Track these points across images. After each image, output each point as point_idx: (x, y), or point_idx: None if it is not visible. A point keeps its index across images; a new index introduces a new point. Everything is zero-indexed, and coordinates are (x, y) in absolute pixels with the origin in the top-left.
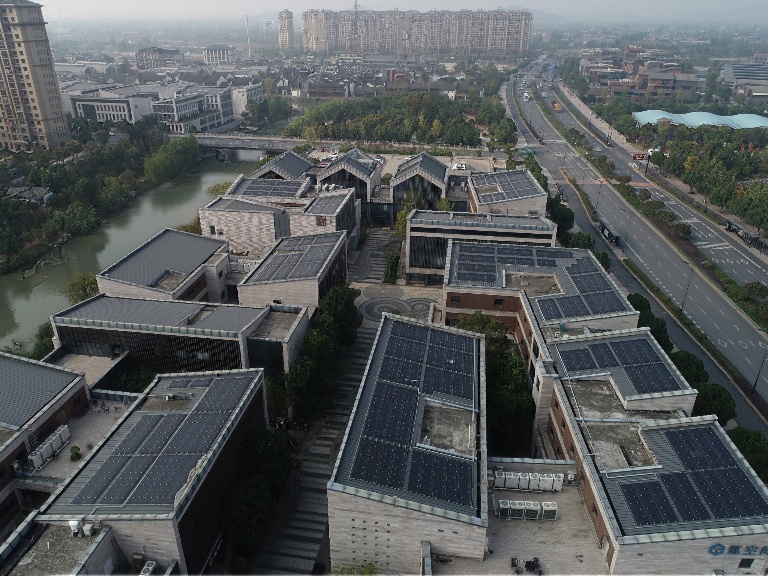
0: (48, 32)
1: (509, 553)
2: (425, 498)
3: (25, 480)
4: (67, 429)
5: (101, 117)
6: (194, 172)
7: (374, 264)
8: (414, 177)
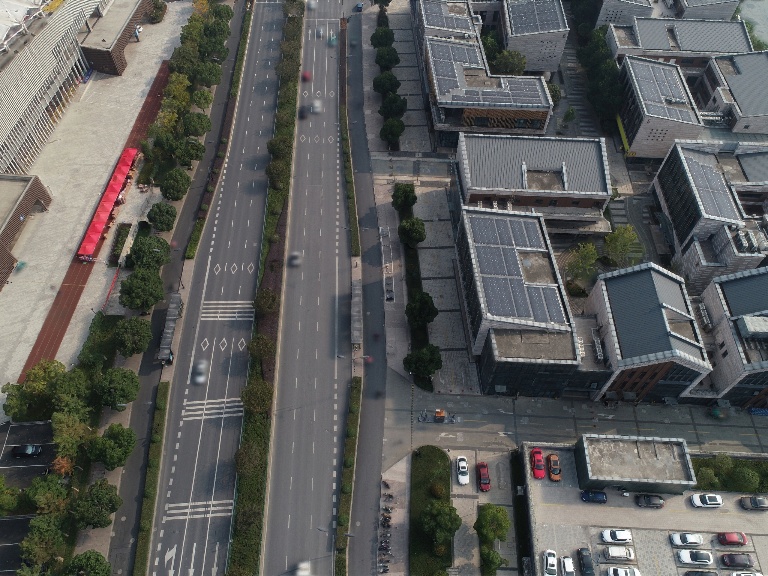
0: None
1: None
2: None
3: None
4: (670, 4)
5: None
6: None
7: None
8: None
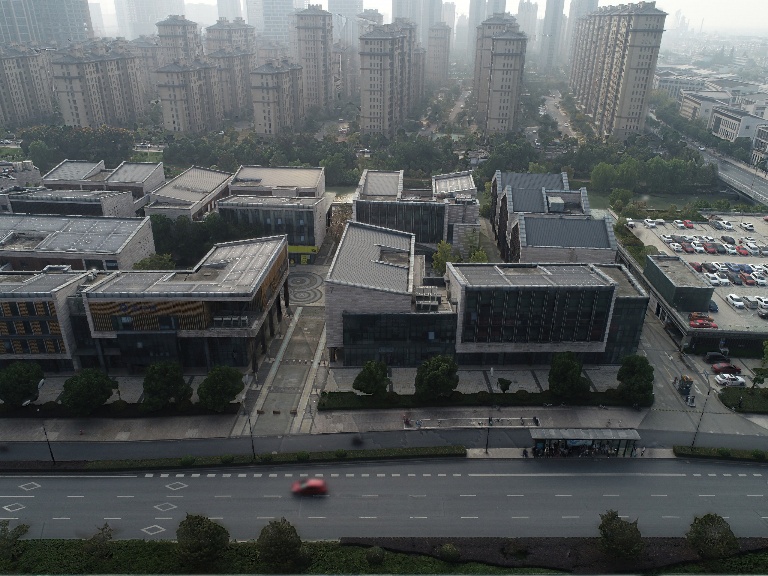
0: (663, 39)
1: None
2: None
3: None
4: None
5: (721, 132)
6: (657, 196)
7: None
8: (517, 225)
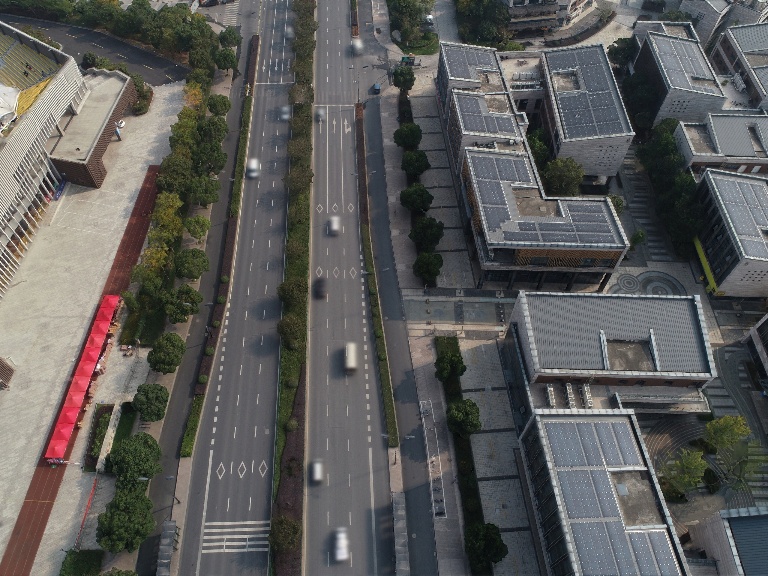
0: None
1: (529, 68)
2: None
3: (732, 75)
4: (742, 88)
5: None
6: None
7: (725, 395)
8: None
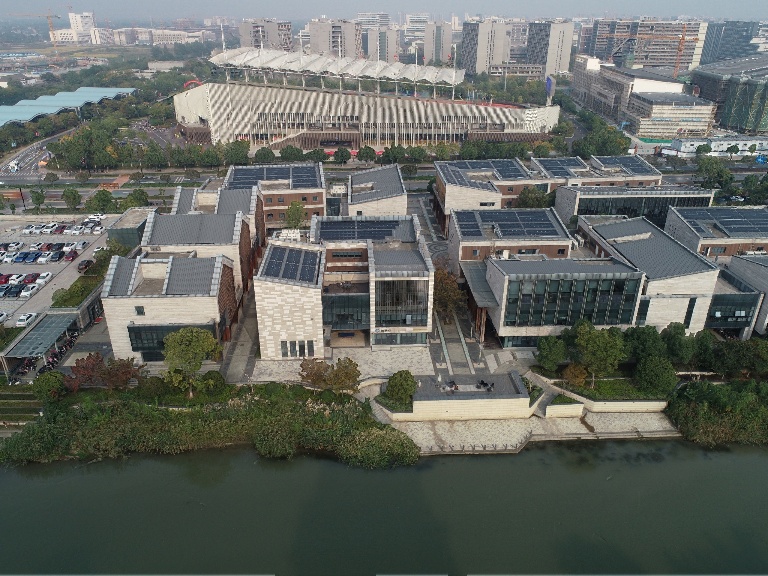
0: None
1: None
2: (687, 188)
3: None
4: None
5: None
6: None
7: None
8: None
